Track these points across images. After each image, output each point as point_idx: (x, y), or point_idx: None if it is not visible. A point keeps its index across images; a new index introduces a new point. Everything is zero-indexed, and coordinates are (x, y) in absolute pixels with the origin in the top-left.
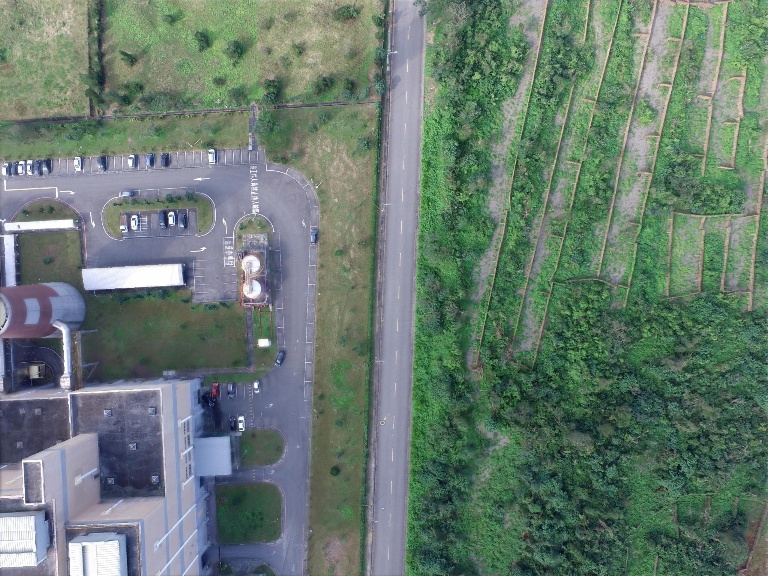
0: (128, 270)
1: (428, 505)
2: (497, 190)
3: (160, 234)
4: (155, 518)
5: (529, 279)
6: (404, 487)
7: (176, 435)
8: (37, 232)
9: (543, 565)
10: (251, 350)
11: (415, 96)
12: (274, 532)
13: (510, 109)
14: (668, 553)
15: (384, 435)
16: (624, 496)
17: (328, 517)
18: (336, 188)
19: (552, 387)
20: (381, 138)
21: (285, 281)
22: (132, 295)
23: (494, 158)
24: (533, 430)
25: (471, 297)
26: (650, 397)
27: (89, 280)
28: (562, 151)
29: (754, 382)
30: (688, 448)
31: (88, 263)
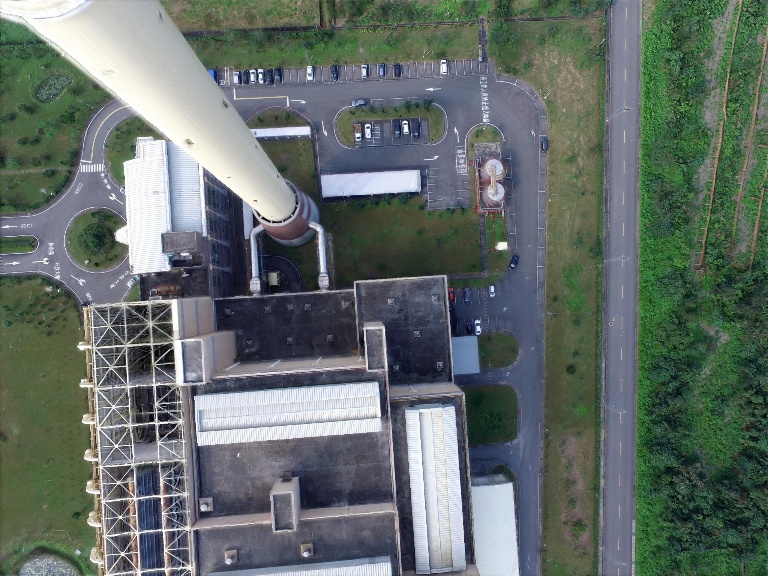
0: (367, 176)
1: (661, 399)
2: (711, 102)
3: (393, 143)
4: None
5: (742, 186)
6: (633, 385)
7: None
8: (269, 141)
9: (765, 453)
10: (484, 256)
11: (634, 13)
12: (511, 432)
13: (720, 27)
14: None
15: (613, 335)
16: None
17: (564, 415)
18: (564, 98)
19: None
20: (604, 52)
21: (516, 188)
22: (372, 201)
23: (707, 72)
24: (756, 325)
25: (692, 202)
26: None
27: (328, 186)
28: (763, 68)
29: None
30: None
31: (321, 172)
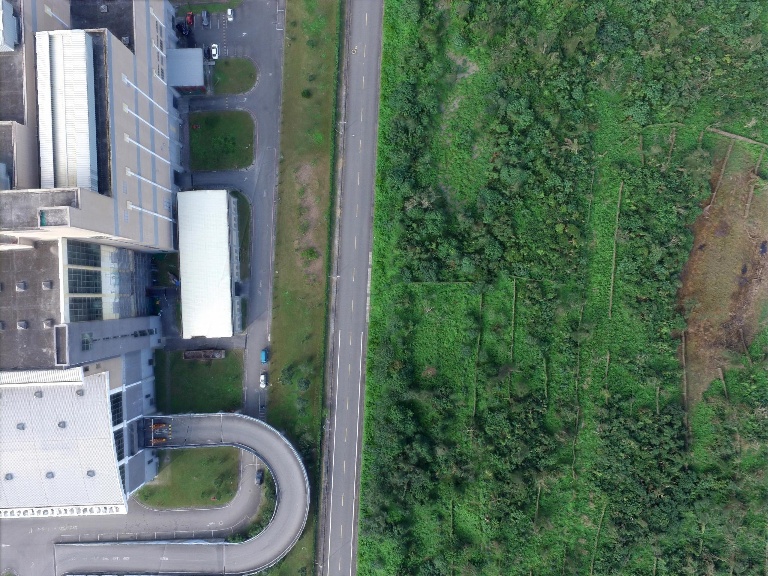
0: None
1: (397, 124)
2: None
3: None
4: (123, 52)
5: None
6: (374, 114)
7: (147, 17)
8: None
9: (510, 186)
10: None
11: None
12: (246, 158)
13: None
14: (633, 177)
15: (355, 64)
16: (590, 122)
17: (299, 141)
18: None
19: (520, 8)
20: None
21: None
22: None
23: None
24: (501, 49)
25: None
26: (616, 24)
27: None
28: None
29: (719, 12)
30: (654, 78)
31: None
